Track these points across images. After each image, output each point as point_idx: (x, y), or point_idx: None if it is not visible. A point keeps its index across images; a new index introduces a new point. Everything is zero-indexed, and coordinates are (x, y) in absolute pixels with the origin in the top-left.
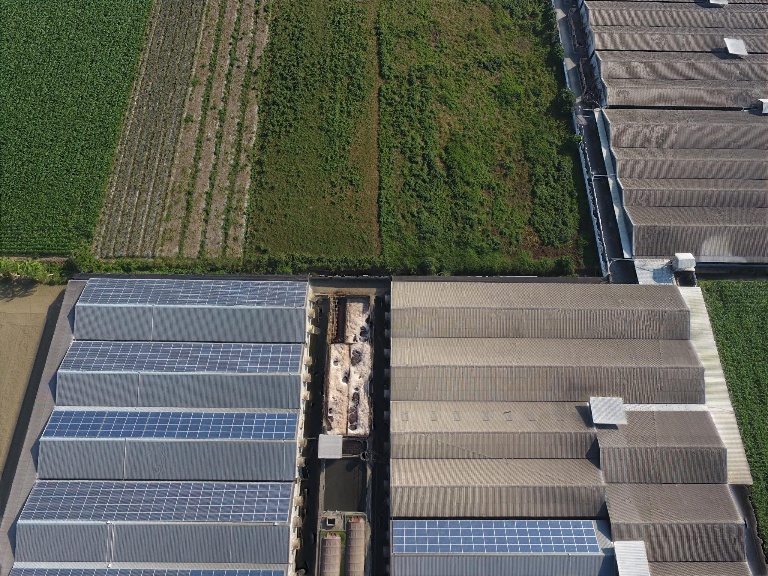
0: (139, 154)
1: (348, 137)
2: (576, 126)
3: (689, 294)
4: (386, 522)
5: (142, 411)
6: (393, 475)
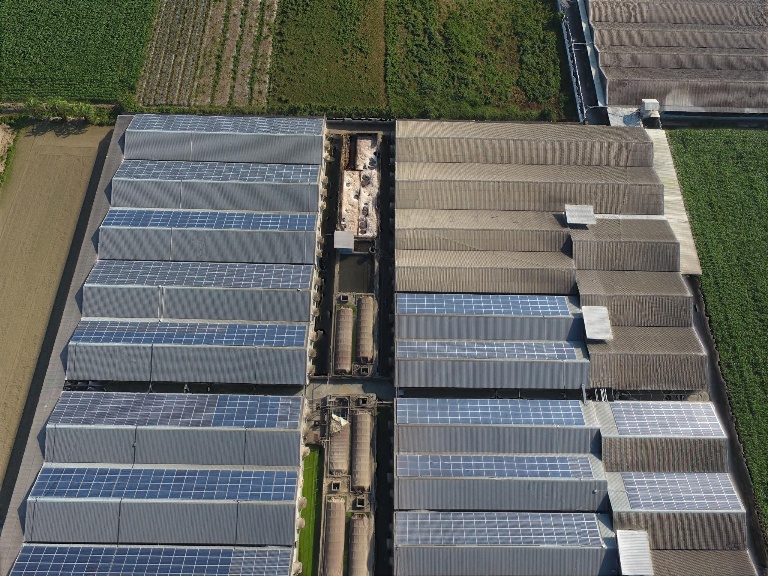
0: (174, 26)
1: (358, 15)
2: (560, 6)
3: (654, 134)
4: (391, 303)
5: (184, 211)
6: (397, 259)
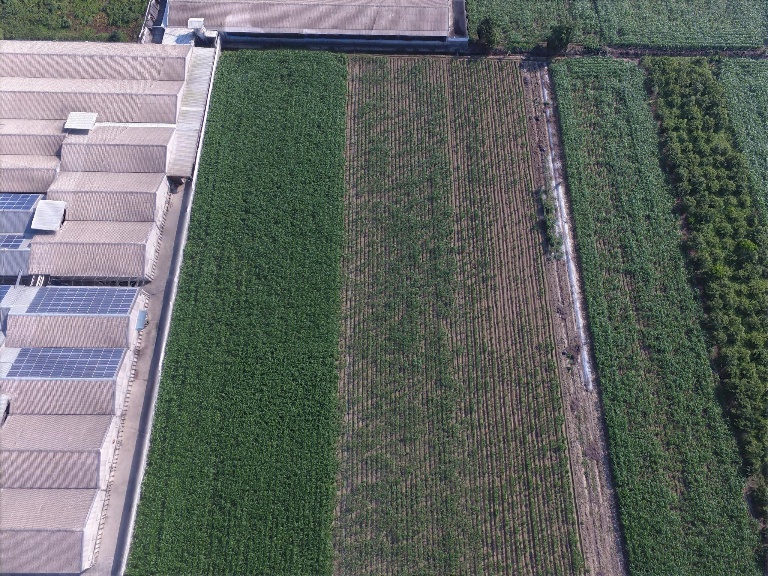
0: None
1: None
2: None
3: (202, 52)
4: None
5: None
6: None
